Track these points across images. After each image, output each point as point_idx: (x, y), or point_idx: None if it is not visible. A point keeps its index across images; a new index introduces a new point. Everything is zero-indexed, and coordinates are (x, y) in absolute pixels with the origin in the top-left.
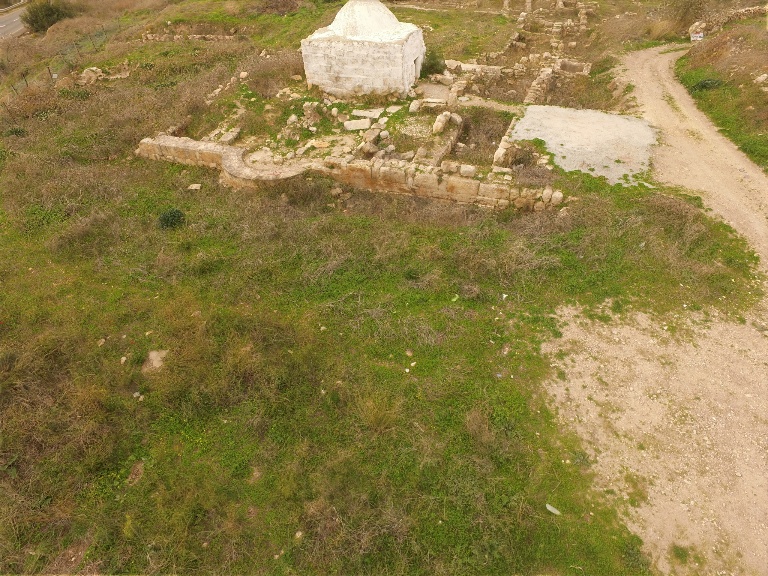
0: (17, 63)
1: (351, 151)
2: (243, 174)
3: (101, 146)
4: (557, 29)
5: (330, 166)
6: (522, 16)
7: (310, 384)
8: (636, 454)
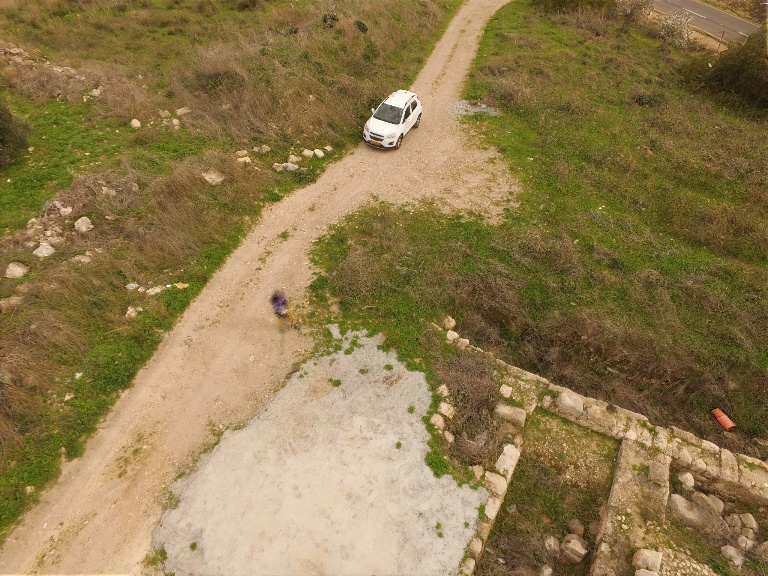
0: None
1: None
2: None
3: None
4: None
5: None
6: None
7: None
8: (486, 168)
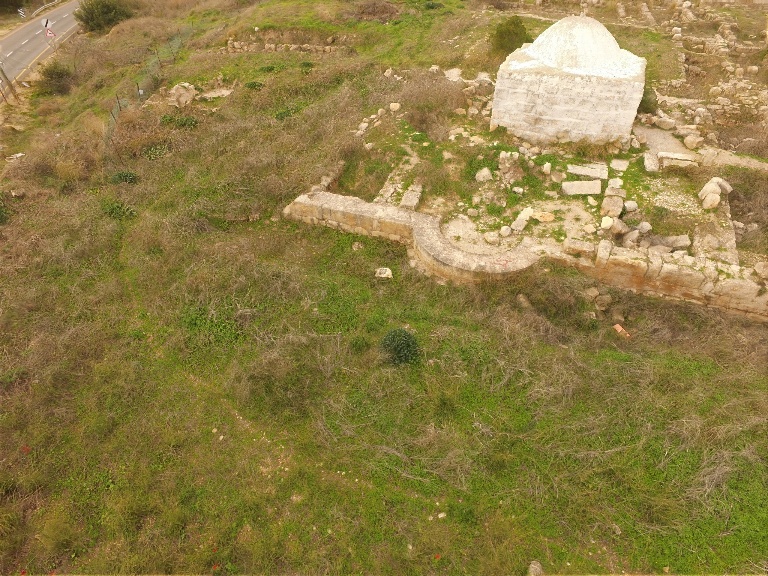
0: (91, 73)
1: (596, 231)
2: (456, 261)
3: (240, 203)
4: (726, 49)
5: (576, 254)
6: (677, 32)
7: None
8: None
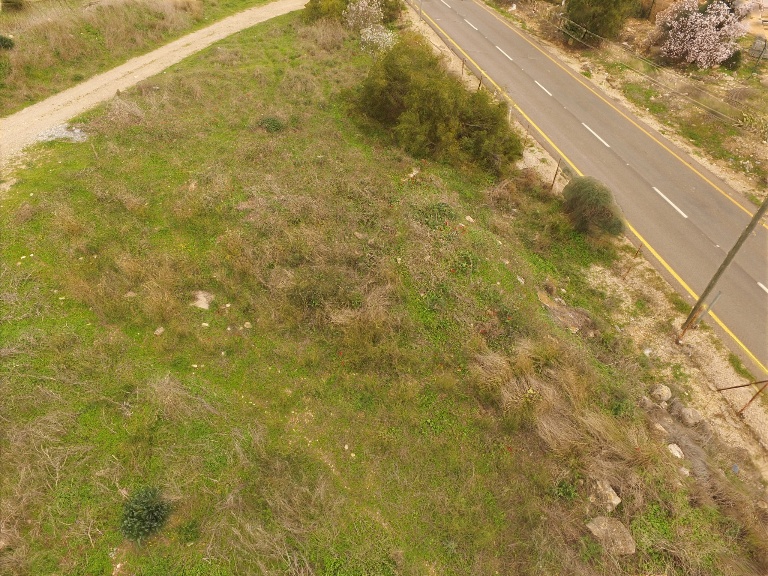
0: None
1: None
2: None
3: None
4: None
5: None
6: None
7: None
8: None
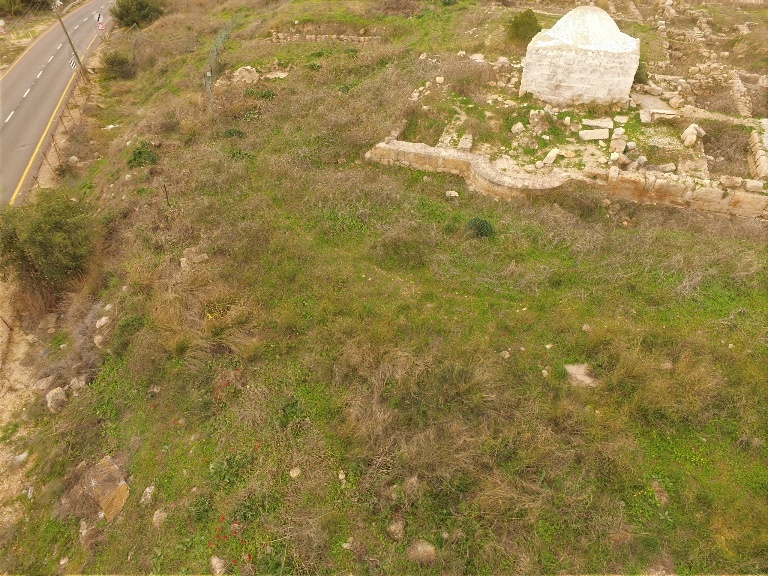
0: (157, 59)
1: (607, 162)
2: (507, 183)
3: (332, 149)
4: (702, 38)
5: (593, 177)
6: (662, 24)
7: (765, 403)
8: None
